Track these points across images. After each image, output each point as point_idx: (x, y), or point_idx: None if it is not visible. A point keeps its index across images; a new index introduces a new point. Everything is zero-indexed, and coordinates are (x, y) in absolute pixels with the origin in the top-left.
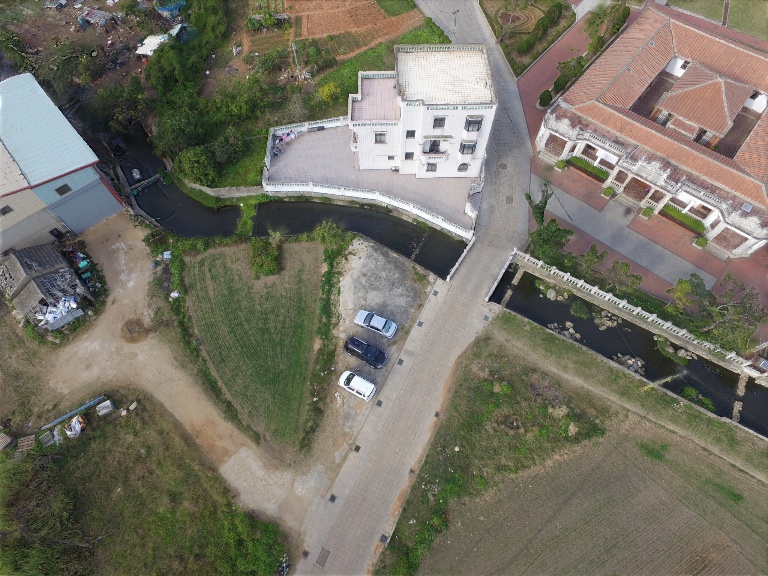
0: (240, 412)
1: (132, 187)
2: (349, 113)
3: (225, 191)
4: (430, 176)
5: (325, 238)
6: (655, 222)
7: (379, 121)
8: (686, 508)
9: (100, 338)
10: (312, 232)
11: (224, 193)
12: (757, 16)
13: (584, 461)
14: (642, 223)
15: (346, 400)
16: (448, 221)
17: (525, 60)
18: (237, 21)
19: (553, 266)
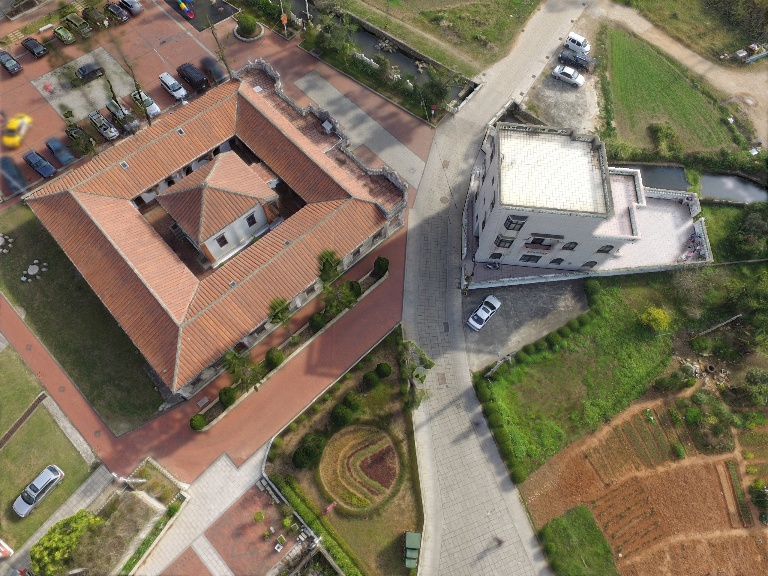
0: (650, 48)
1: None
2: None
3: None
4: None
5: None
6: None
7: None
8: None
9: None
10: None
11: None
12: None
13: (437, 4)
14: None
15: None
16: None
17: (380, 360)
18: None
19: None
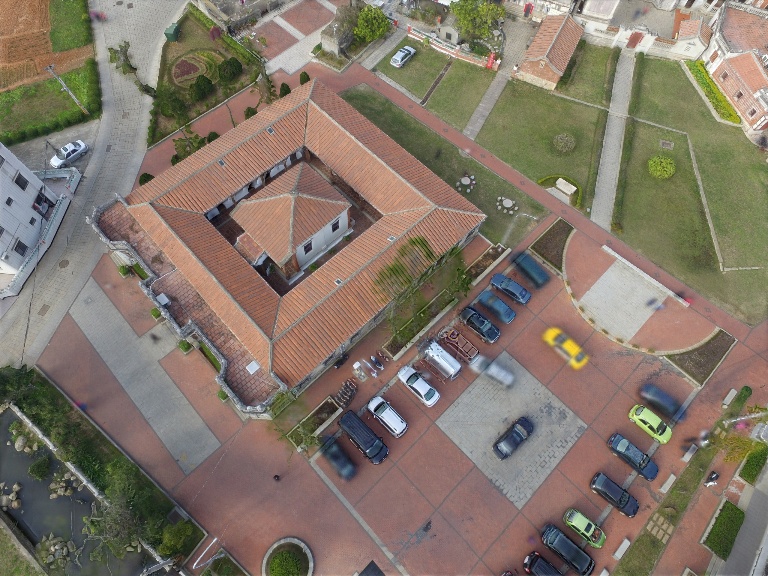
0: None
1: None
2: None
3: None
4: None
5: None
6: (194, 359)
7: None
8: None
9: None
10: None
11: None
12: (466, 96)
13: None
14: (178, 358)
15: None
16: None
17: (171, 125)
18: None
19: (20, 411)
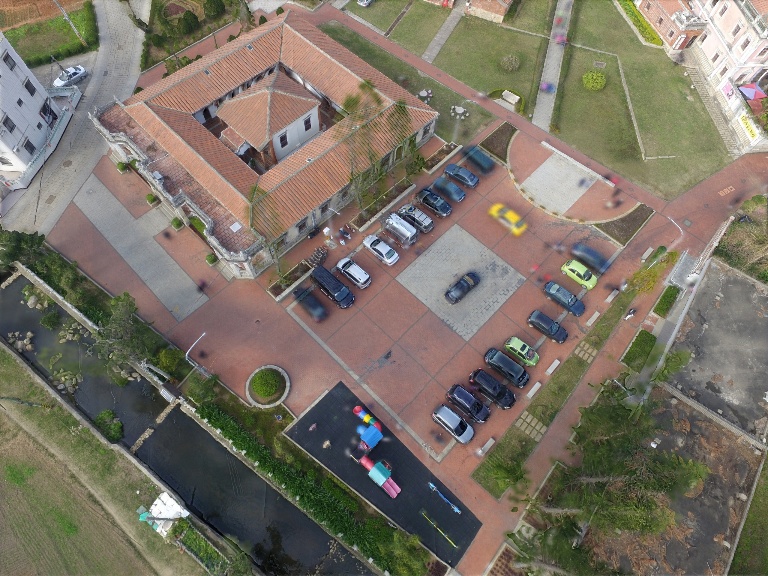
0: None
1: None
2: None
3: None
4: None
5: None
6: (184, 235)
7: None
8: (13, 536)
9: None
10: None
11: None
12: (425, 28)
13: None
14: (171, 234)
15: None
16: None
17: (162, 54)
18: None
19: (32, 272)
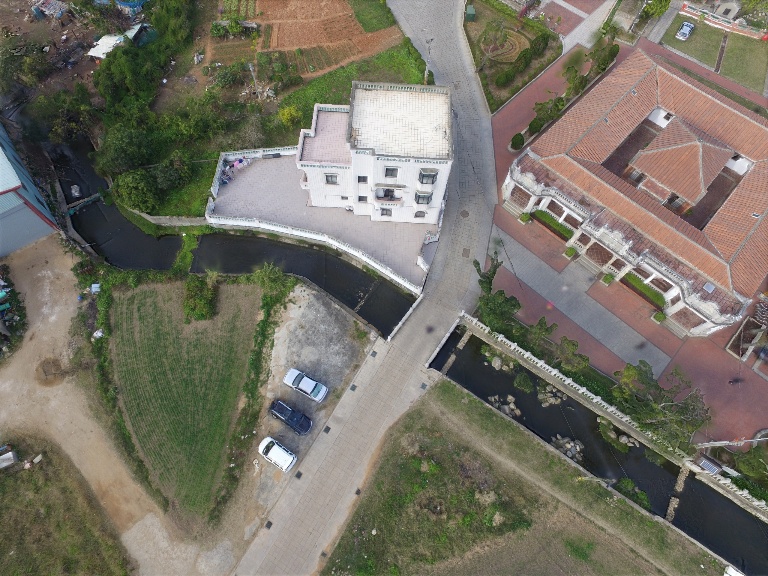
0: (151, 474)
1: (69, 206)
2: (298, 152)
3: (166, 220)
4: (385, 220)
5: (265, 282)
6: (615, 289)
7: (329, 164)
8: None
9: (12, 378)
10: (252, 274)
11: (165, 221)
12: (752, 64)
13: (505, 555)
14: (601, 290)
15: (264, 469)
16: (396, 274)
17: (503, 94)
18: (203, 24)
19: (500, 334)
